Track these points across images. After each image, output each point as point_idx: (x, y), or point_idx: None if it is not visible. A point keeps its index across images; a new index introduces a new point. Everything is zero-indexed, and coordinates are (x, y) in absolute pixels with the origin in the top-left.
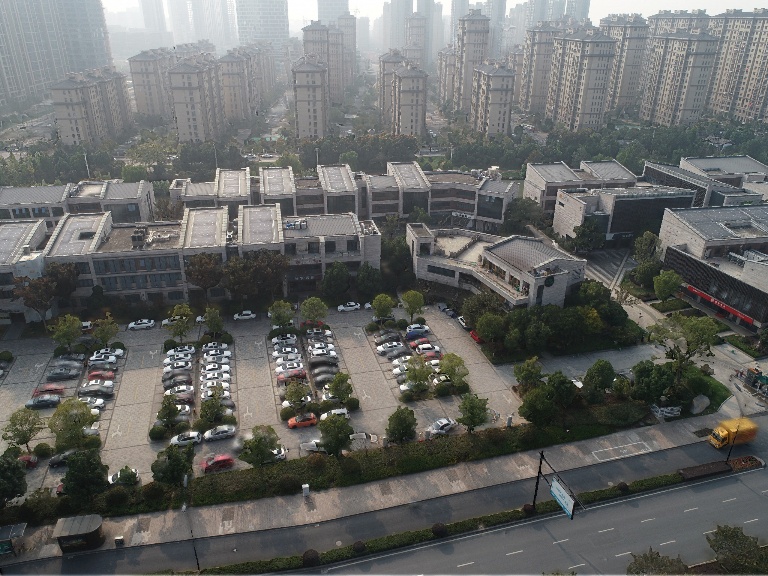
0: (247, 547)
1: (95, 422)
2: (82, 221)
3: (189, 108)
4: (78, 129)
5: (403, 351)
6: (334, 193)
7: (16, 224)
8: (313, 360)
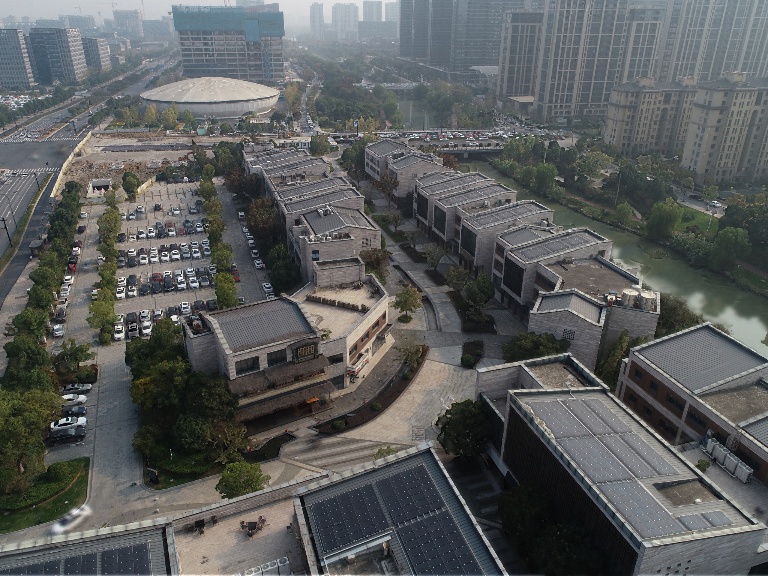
0: (3, 286)
1: (136, 239)
2: (312, 162)
3: (700, 131)
4: (615, 131)
5: (170, 309)
6: (466, 224)
7: (303, 153)
8: (166, 277)
